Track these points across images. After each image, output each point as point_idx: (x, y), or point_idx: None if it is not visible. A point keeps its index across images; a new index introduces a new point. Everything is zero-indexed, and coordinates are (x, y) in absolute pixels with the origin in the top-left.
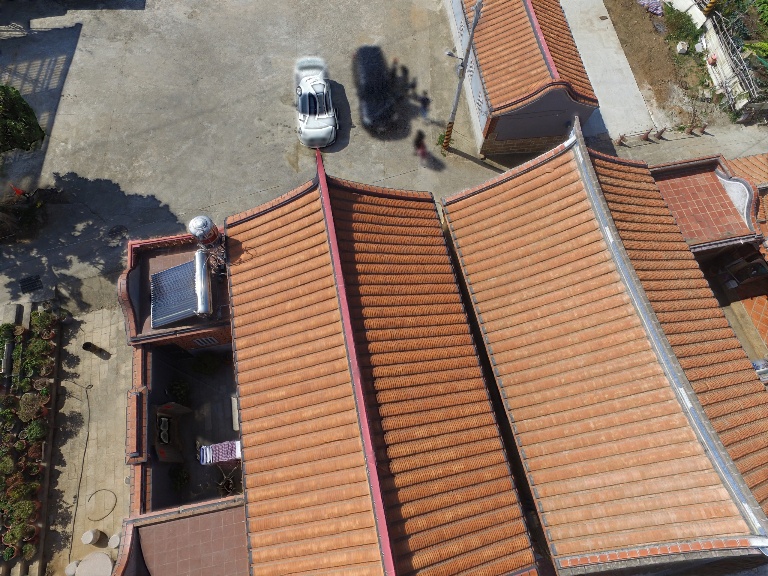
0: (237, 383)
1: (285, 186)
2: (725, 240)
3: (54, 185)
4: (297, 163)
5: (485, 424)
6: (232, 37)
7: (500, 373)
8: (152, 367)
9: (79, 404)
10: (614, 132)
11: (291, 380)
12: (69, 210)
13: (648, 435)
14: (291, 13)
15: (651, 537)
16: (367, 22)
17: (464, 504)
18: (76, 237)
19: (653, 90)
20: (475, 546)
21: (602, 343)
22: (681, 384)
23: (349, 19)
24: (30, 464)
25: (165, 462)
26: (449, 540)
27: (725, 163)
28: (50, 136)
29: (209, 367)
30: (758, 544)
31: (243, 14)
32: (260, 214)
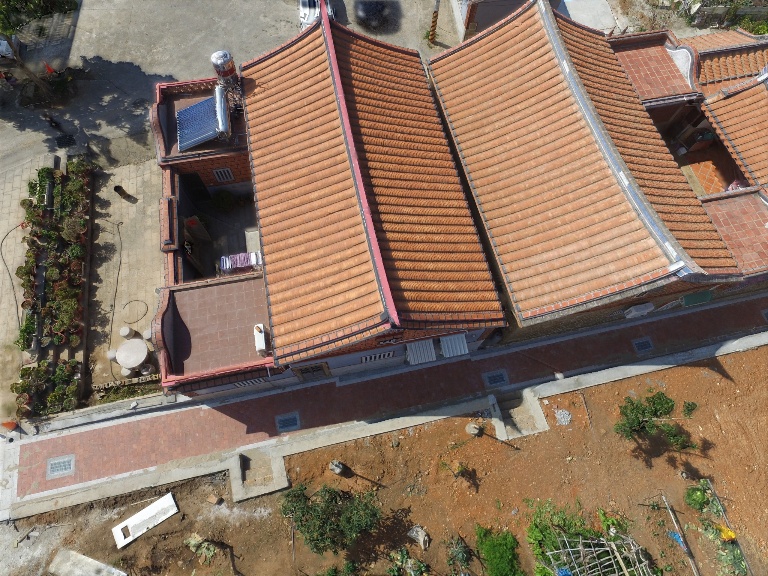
0: (254, 183)
1: None
2: (671, 97)
3: (82, 66)
4: None
5: (462, 215)
6: None
7: (475, 186)
8: (179, 185)
9: (112, 237)
10: None
11: (300, 174)
12: (96, 85)
13: (595, 214)
14: None
15: (595, 286)
16: None
17: (443, 263)
18: (104, 106)
19: None
20: (452, 289)
21: (559, 152)
22: (621, 168)
23: None
24: (73, 275)
25: (191, 264)
26: (431, 281)
27: (672, 35)
28: (76, 27)
29: (226, 201)
30: (675, 268)
31: None
32: (271, 56)
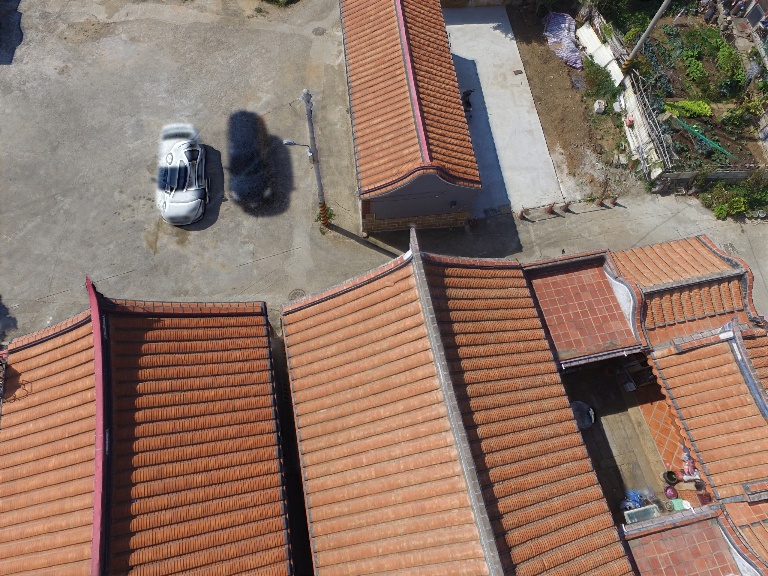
0: None
1: (138, 271)
2: (606, 352)
3: None
4: (156, 243)
5: None
6: (104, 96)
7: (315, 534)
8: None
9: None
10: (517, 204)
11: (37, 564)
12: None
13: None
14: (174, 68)
15: None
16: (256, 78)
17: None
18: None
19: (565, 154)
20: None
21: (425, 507)
22: None
23: (237, 75)
24: None
25: None
26: None
27: (611, 260)
28: None
29: None
30: None
31: (120, 69)
32: (43, 340)
